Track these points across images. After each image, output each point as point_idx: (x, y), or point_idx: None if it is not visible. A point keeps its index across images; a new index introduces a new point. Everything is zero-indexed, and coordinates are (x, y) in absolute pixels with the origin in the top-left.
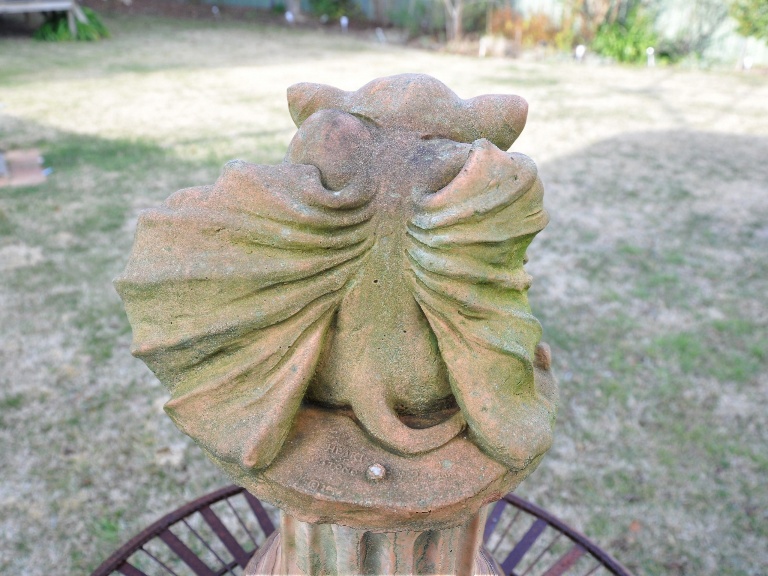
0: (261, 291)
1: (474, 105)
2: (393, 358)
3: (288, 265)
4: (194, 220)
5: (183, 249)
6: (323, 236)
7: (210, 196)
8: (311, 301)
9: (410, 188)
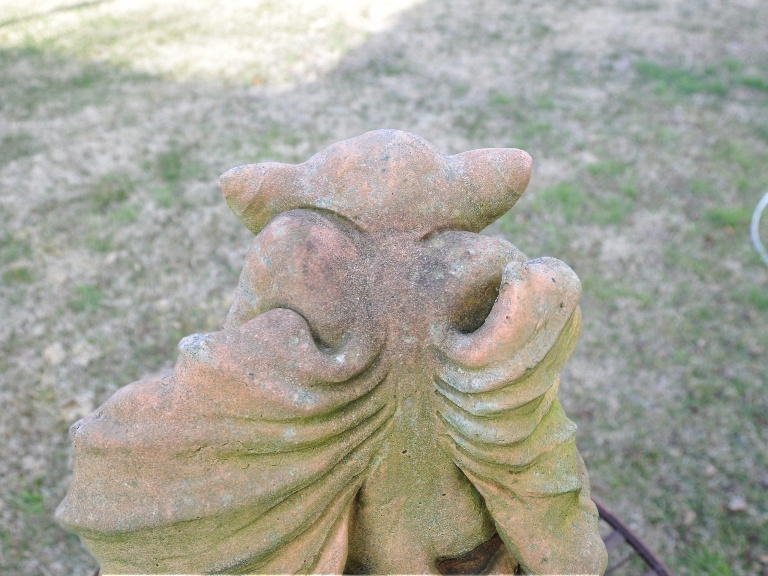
0: (270, 509)
1: (468, 170)
2: (432, 523)
3: (299, 472)
4: (161, 444)
5: (154, 482)
6: (334, 420)
7: (174, 402)
8: (332, 498)
9: (427, 326)
